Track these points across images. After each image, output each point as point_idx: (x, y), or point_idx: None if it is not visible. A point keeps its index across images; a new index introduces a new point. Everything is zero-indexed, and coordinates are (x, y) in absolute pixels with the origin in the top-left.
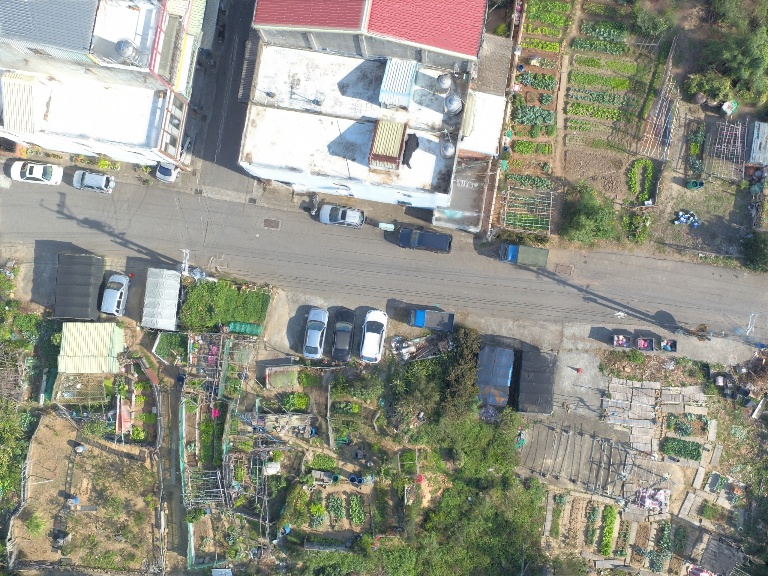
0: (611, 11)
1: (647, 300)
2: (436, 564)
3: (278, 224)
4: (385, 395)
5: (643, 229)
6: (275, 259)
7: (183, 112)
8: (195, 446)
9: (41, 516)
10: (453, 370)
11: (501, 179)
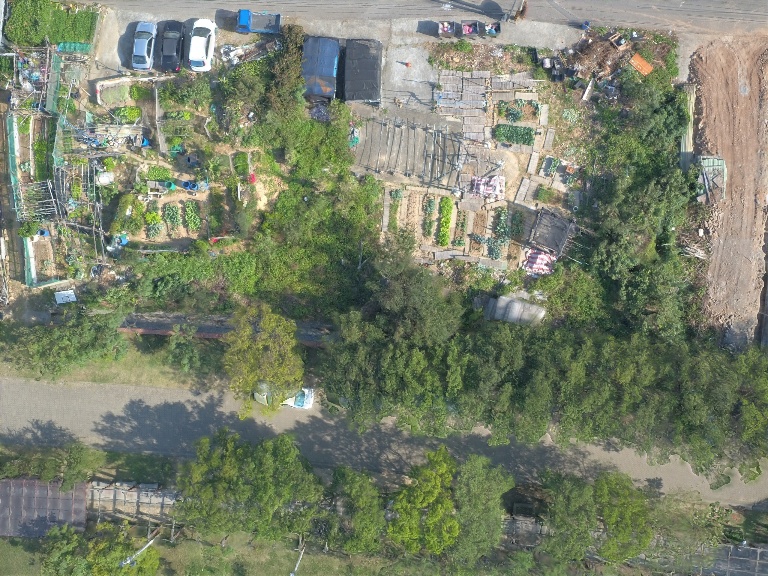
0: None
1: None
2: (275, 265)
3: None
4: (216, 102)
5: None
6: None
7: None
8: (29, 166)
9: None
10: (278, 64)
11: None
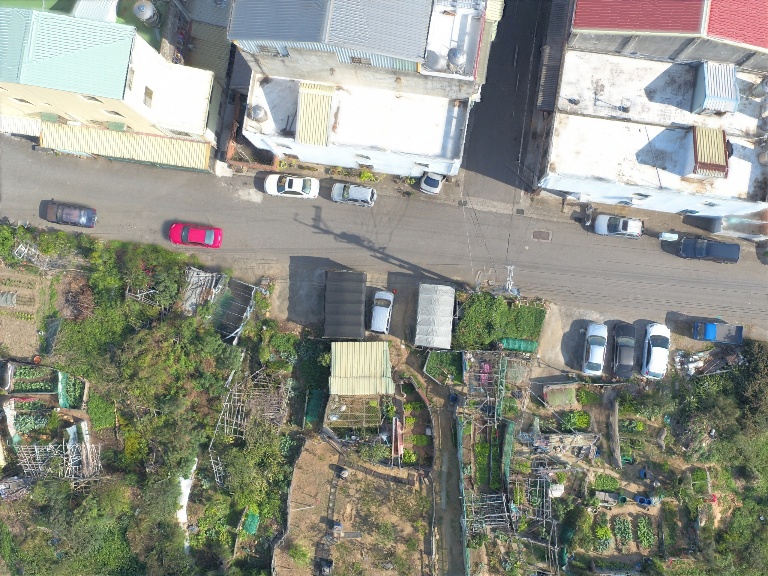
0: None
1: None
2: None
3: (548, 235)
4: (670, 412)
5: None
6: (546, 272)
7: None
8: (471, 468)
9: (302, 544)
10: (750, 385)
11: None
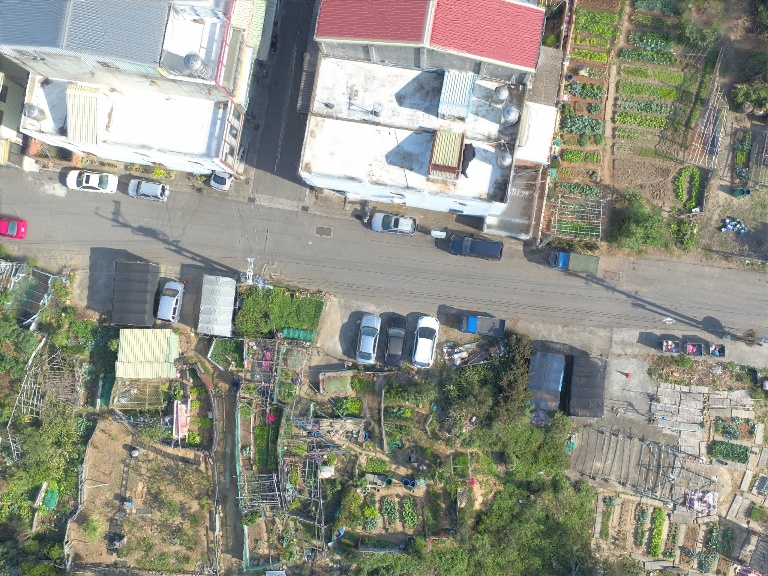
0: (658, 22)
1: (695, 306)
2: (488, 566)
3: (330, 232)
4: (437, 400)
5: (691, 236)
6: (327, 266)
7: (240, 122)
8: (250, 450)
9: (97, 519)
10: (505, 375)
11: (550, 187)
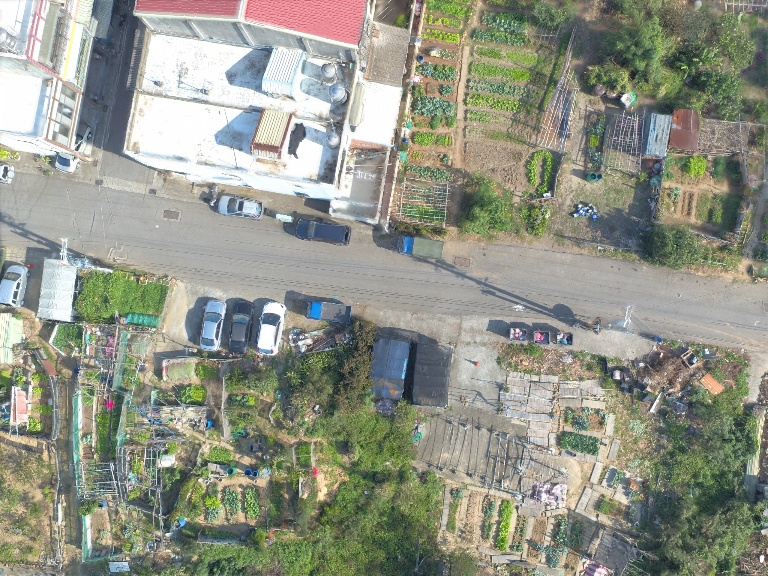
0: (512, 2)
1: (545, 293)
2: (331, 558)
3: (178, 215)
4: (282, 388)
5: (542, 221)
6: (174, 250)
7: (76, 101)
8: (91, 438)
9: None
10: (347, 362)
11: (401, 171)
